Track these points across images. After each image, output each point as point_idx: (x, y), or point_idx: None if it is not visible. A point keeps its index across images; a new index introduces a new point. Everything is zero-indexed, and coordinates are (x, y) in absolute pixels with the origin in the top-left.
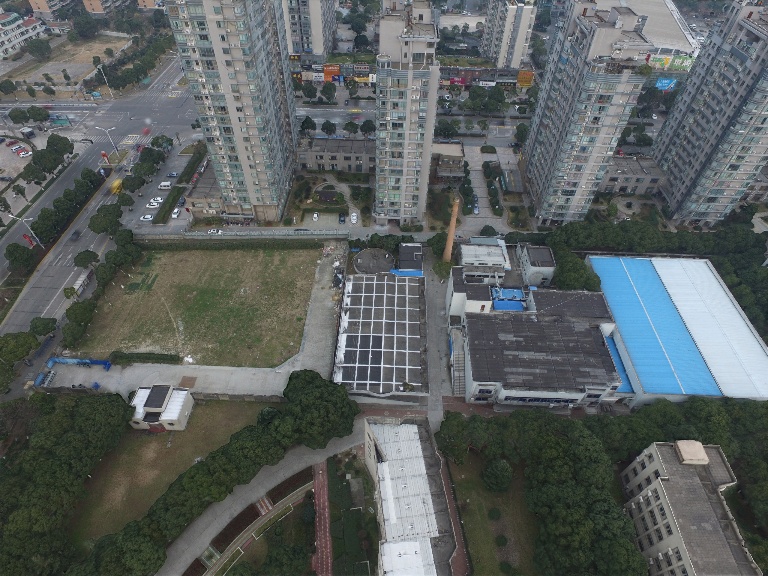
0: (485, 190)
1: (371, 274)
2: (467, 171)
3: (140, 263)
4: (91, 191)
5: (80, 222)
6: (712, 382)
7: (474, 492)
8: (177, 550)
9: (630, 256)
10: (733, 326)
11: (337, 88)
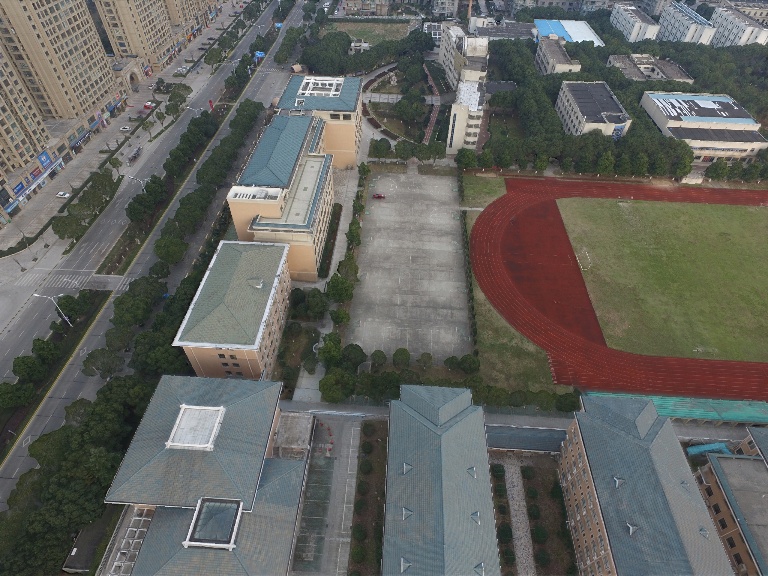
0: (486, 11)
1: (435, 23)
2: (477, 2)
3: (327, 25)
4: None
5: (292, 15)
6: None
7: None
8: (376, 71)
9: None
10: (588, 34)
11: None
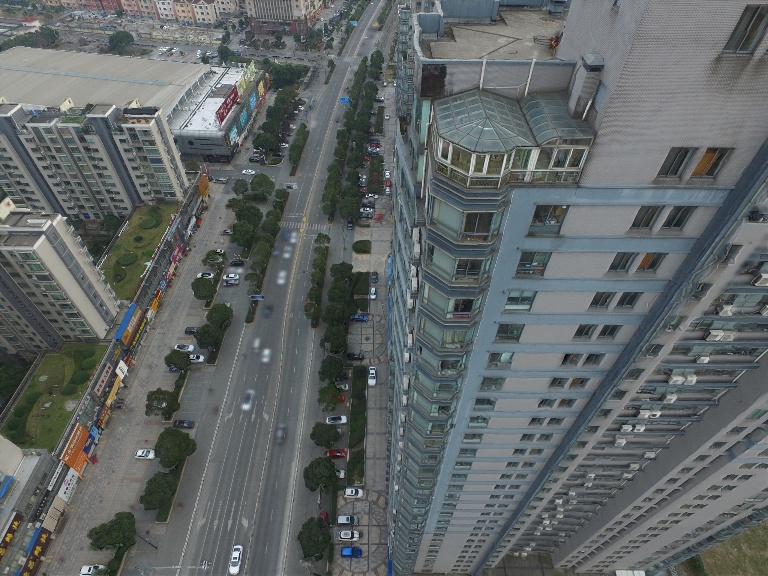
0: None
1: None
2: None
3: None
4: None
5: None
6: None
7: None
8: None
9: None
10: None
11: (104, 451)
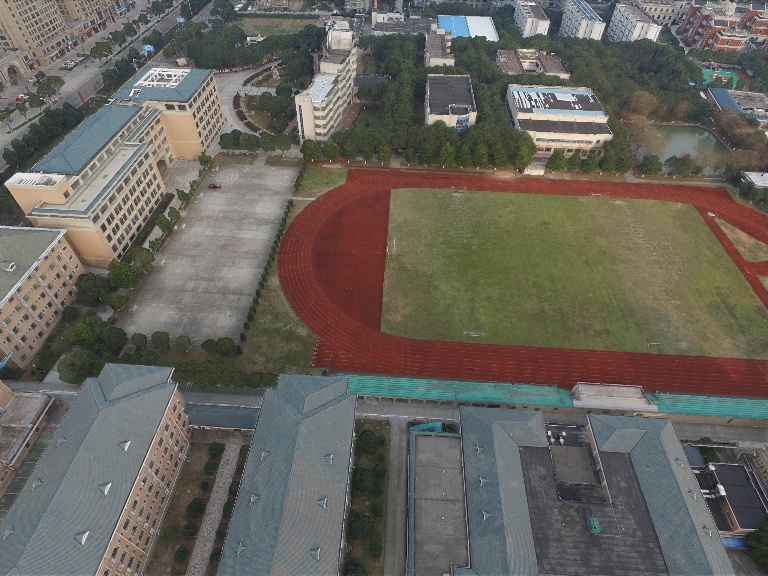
0: None
1: None
2: None
3: (237, 20)
4: (207, 1)
5: (205, 10)
6: None
7: (371, 61)
8: None
9: (456, 15)
10: None
11: None
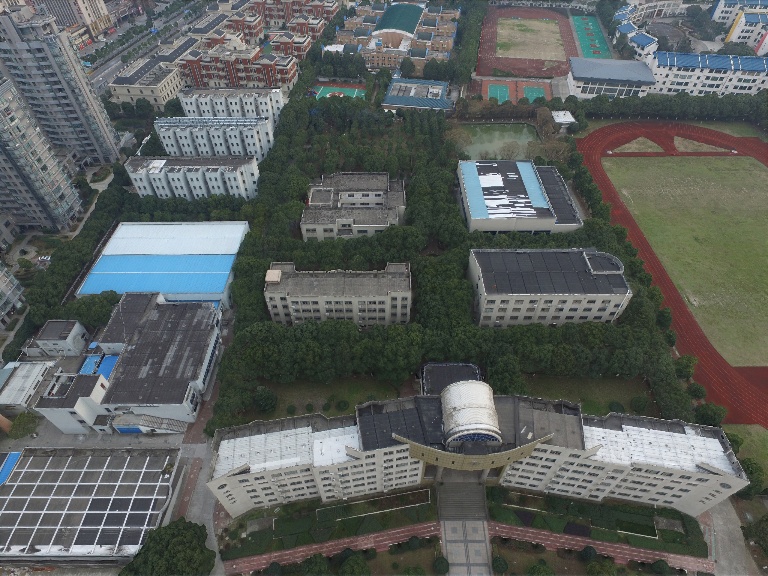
0: None
1: None
2: None
3: None
4: None
5: None
6: (224, 256)
7: None
8: None
9: (92, 266)
10: (185, 231)
11: None
